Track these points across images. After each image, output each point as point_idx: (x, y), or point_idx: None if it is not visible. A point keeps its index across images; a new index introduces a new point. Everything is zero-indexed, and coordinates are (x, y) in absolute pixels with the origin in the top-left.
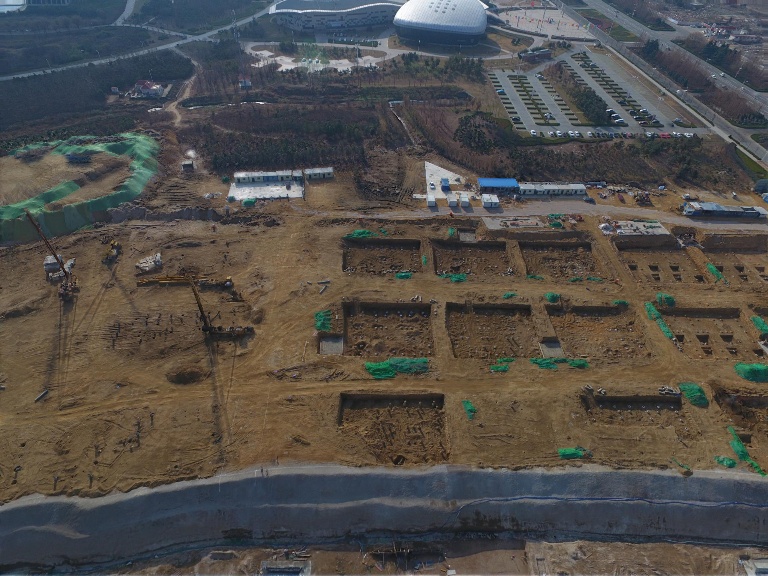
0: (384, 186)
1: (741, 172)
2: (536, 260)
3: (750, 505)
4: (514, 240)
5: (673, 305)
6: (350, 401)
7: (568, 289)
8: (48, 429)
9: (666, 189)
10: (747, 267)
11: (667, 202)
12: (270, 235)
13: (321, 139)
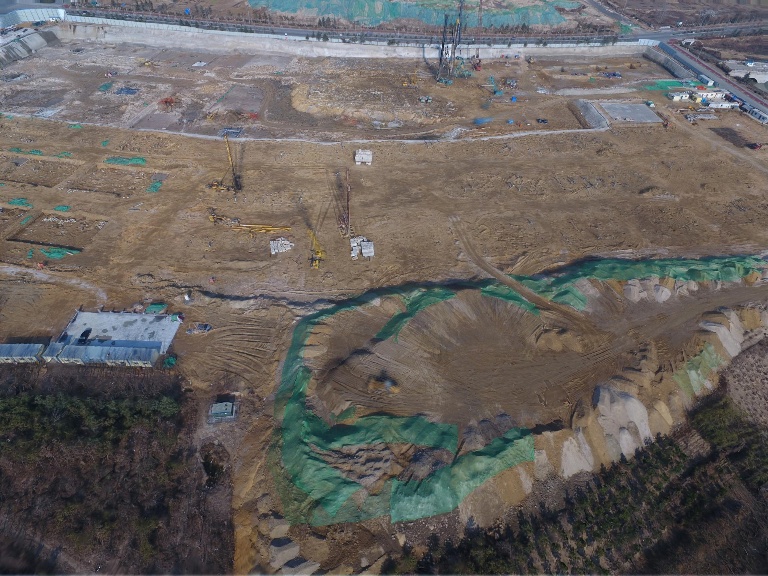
0: None
1: None
2: None
3: None
4: None
5: None
6: None
7: None
8: (328, 162)
9: None
10: None
11: None
12: (155, 262)
13: None
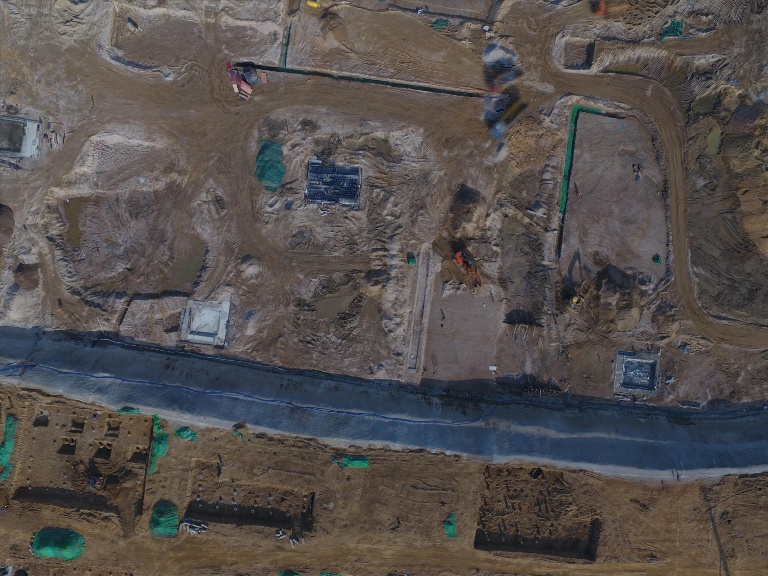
0: None
1: None
2: None
3: (189, 389)
4: None
5: None
6: (580, 550)
7: None
8: None
9: None
10: None
11: None
12: None
13: None
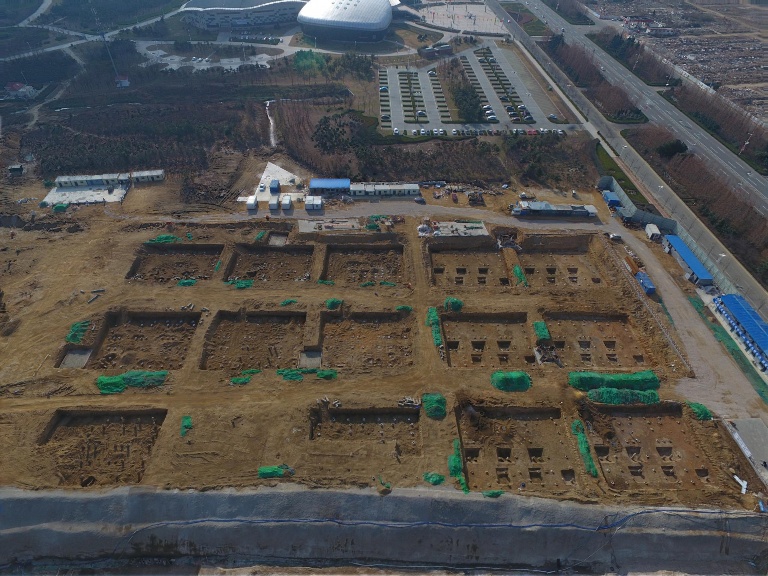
0: (212, 188)
1: (593, 169)
2: (340, 264)
3: (444, 525)
4: (324, 243)
5: (458, 310)
6: (68, 418)
7: (355, 294)
8: None
9: (508, 188)
10: (559, 268)
11: (501, 201)
12: (67, 242)
13: (171, 140)
